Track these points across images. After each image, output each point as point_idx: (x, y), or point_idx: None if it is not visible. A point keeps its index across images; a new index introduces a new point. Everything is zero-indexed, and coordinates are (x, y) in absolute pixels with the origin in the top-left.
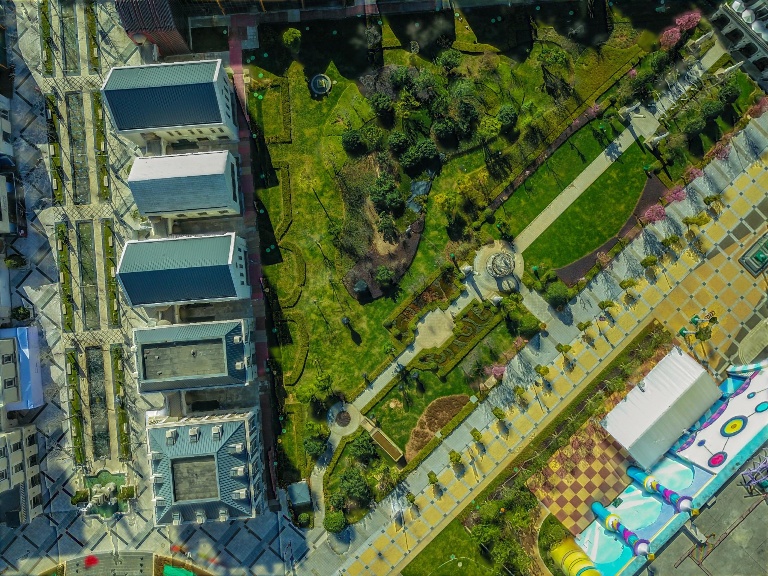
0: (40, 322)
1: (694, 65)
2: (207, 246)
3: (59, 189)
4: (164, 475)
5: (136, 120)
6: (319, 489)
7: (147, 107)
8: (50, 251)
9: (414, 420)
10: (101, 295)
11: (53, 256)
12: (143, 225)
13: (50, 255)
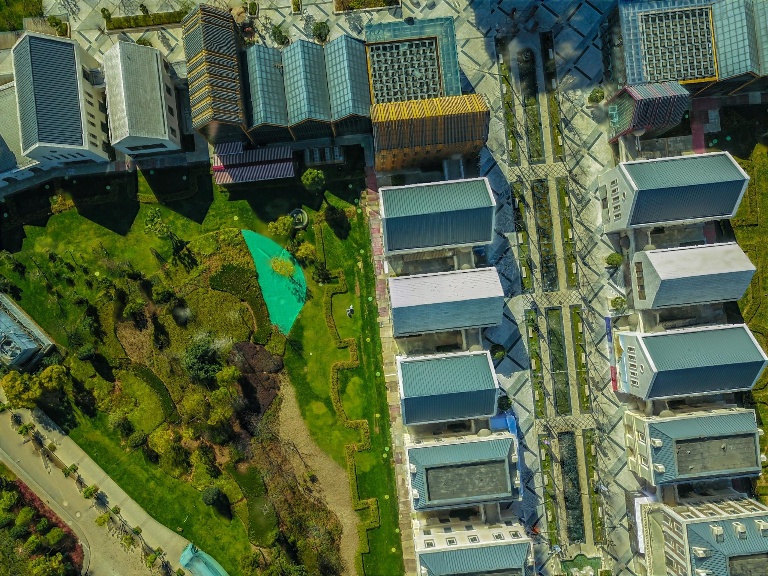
0: (513, 409)
1: None
2: (727, 339)
3: (527, 277)
4: (716, 572)
5: (651, 215)
6: None
7: (669, 203)
8: (520, 338)
9: None
10: (572, 381)
11: (523, 343)
12: (612, 311)
13: (520, 342)
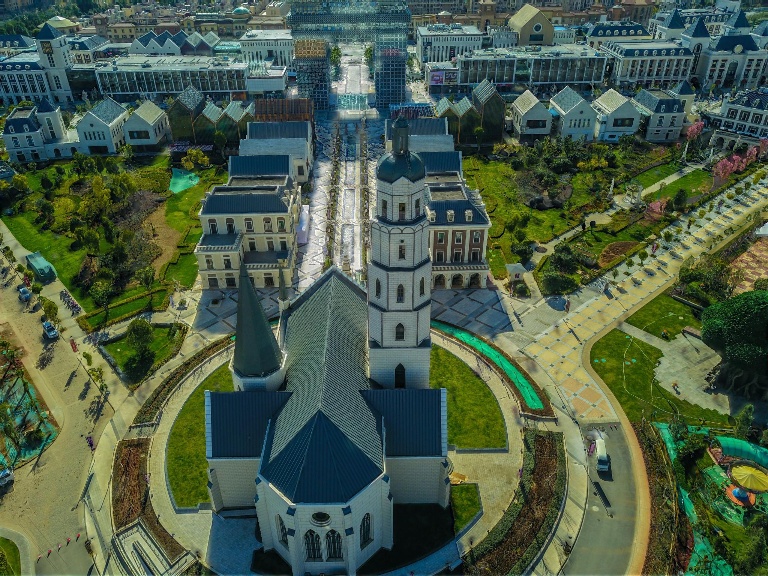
0: (312, 216)
1: (714, 154)
2: None
3: (336, 181)
4: None
5: None
6: (530, 279)
7: None
8: None
9: (599, 250)
10: (356, 209)
11: None
12: None
13: None
